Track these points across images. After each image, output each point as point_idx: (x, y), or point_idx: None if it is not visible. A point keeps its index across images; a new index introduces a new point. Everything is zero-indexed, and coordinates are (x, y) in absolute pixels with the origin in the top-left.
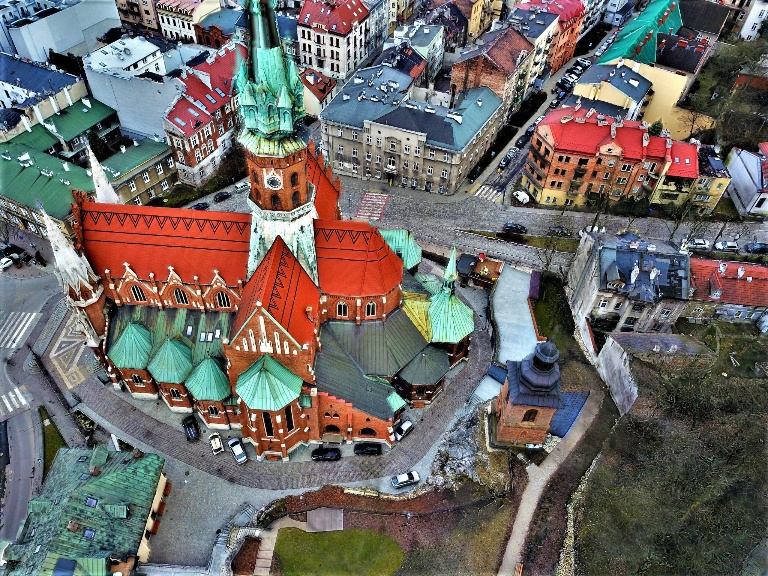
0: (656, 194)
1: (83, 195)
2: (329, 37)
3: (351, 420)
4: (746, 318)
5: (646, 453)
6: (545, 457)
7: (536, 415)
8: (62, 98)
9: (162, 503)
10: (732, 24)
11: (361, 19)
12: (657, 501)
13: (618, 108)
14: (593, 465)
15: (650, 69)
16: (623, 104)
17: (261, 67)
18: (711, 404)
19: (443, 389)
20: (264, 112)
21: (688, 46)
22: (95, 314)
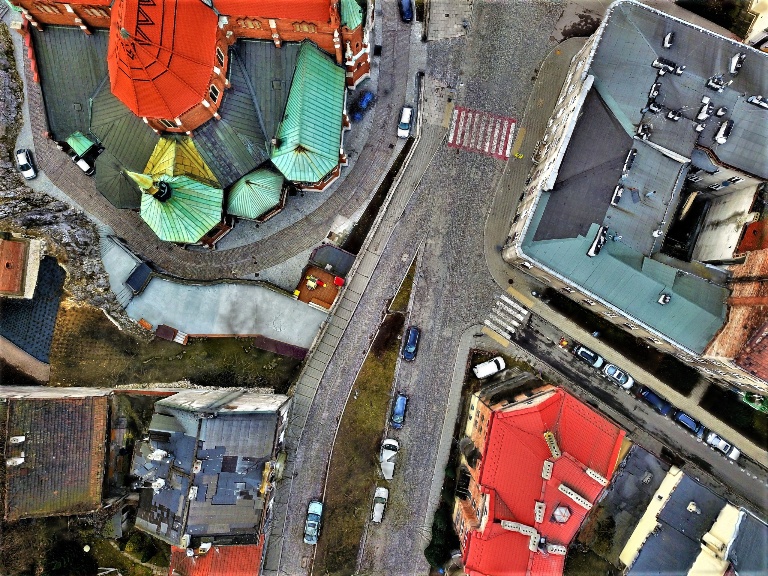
0: None
1: None
2: None
3: None
4: None
5: None
6: None
7: None
8: None
9: None
10: None
11: None
12: None
13: None
14: None
15: None
16: None
17: None
18: None
19: None
20: None
21: None
22: None
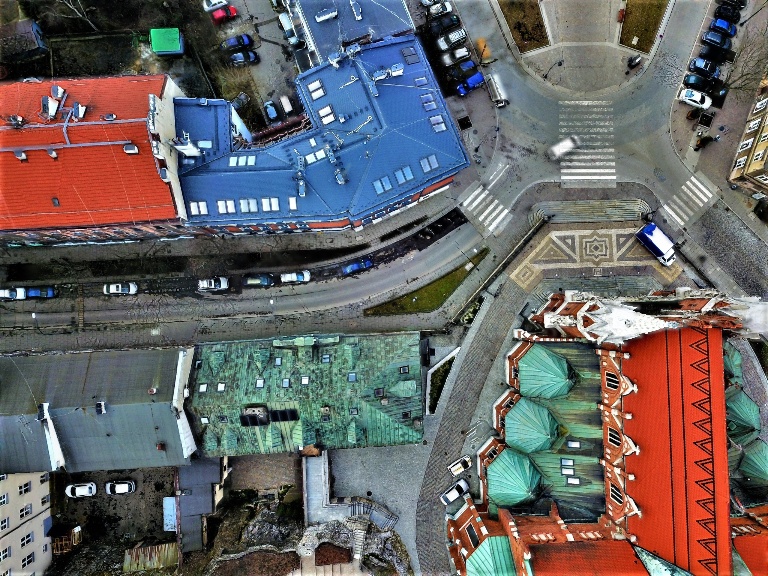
0: None
1: None
2: None
3: None
4: None
5: None
6: None
7: None
8: None
9: None
10: None
11: None
12: None
13: None
14: None
15: None
16: None
17: None
18: None
19: None
20: None
21: None
22: None
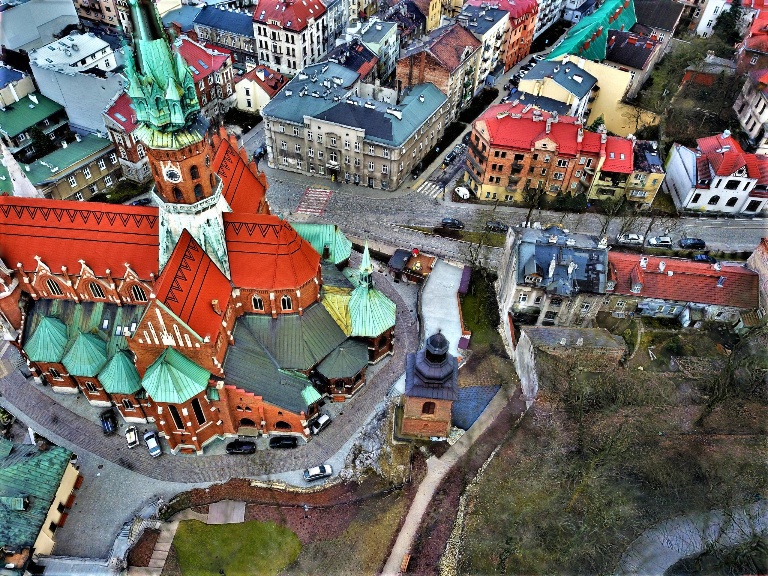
0: (593, 190)
1: None
2: (284, 34)
3: (263, 413)
4: (668, 312)
5: (546, 445)
6: (447, 450)
7: (435, 407)
8: (7, 94)
9: (72, 496)
10: (688, 21)
11: (317, 16)
12: (547, 493)
13: (561, 104)
14: (491, 457)
15: (595, 65)
16: (566, 100)
17: (145, 59)
18: (619, 397)
19: (365, 383)
20: (152, 104)
21: (638, 43)
22: (10, 308)
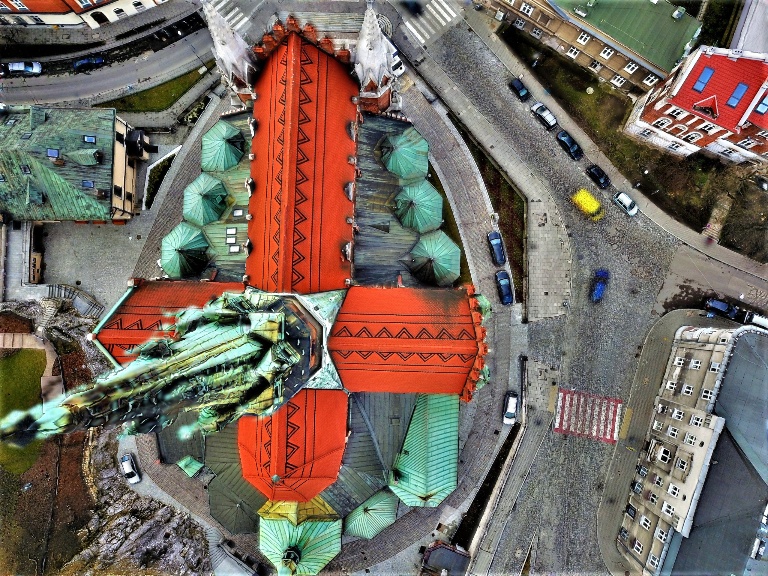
0: None
1: (305, 29)
2: None
3: None
4: None
5: None
6: None
7: None
8: None
9: (104, 221)
10: None
11: None
12: None
13: None
14: None
15: None
16: None
17: None
18: None
19: None
20: None
21: None
22: None
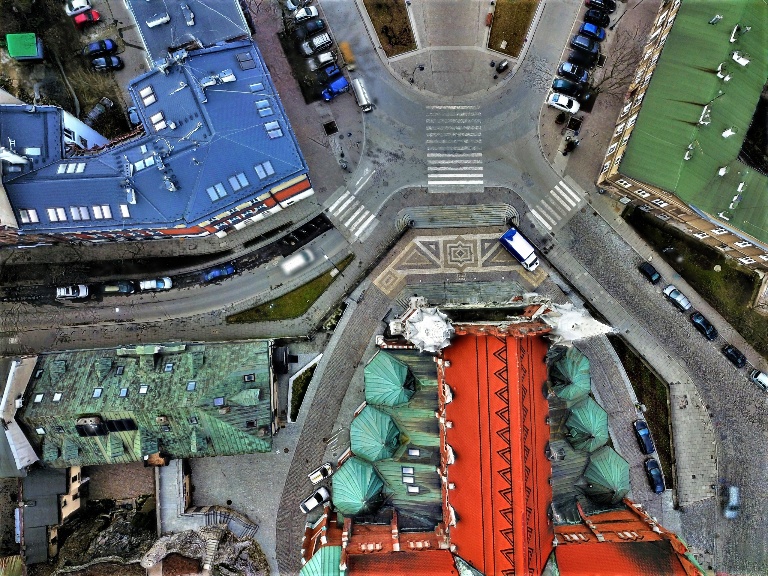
0: None
1: (529, 334)
2: None
3: None
4: None
5: None
6: None
7: None
8: None
9: None
10: None
11: None
12: None
13: None
14: None
15: None
16: None
17: None
18: None
19: None
20: None
21: None
22: None
